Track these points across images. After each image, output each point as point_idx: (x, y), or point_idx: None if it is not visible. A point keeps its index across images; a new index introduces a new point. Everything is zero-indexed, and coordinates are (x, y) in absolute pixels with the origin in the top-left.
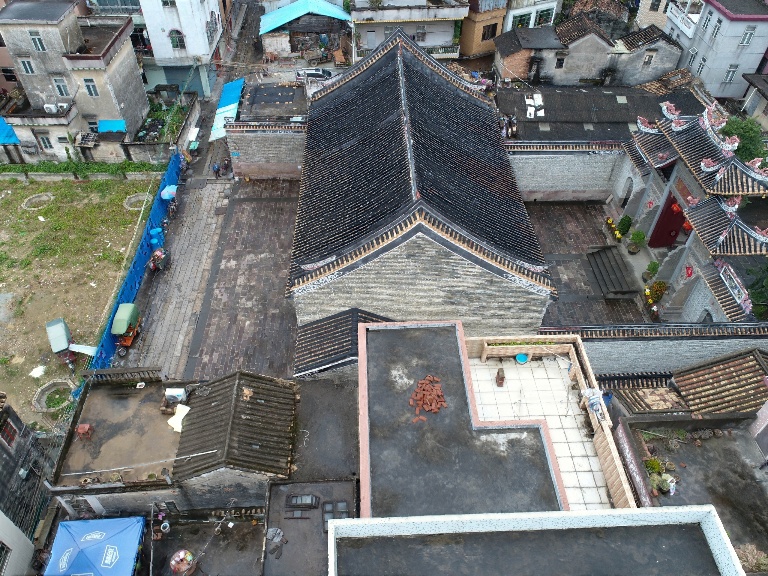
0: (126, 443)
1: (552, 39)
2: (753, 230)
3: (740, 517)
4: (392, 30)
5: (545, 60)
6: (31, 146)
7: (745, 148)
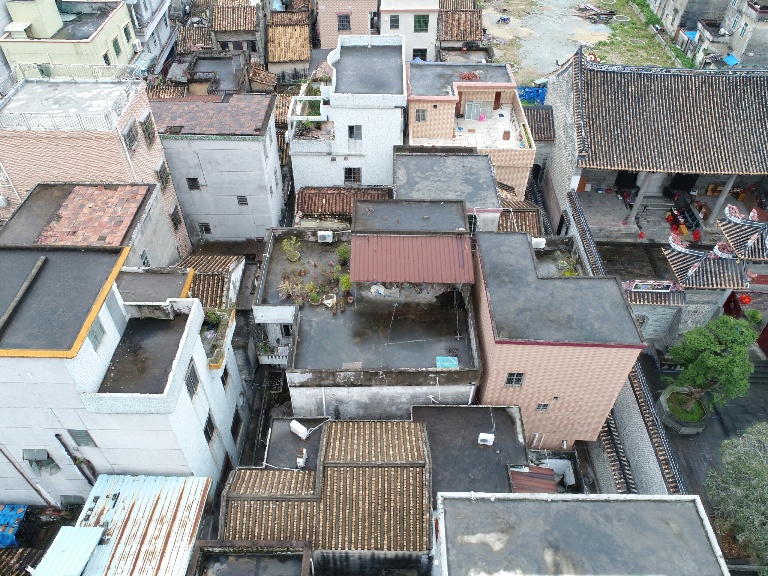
0: (461, 60)
1: None
2: None
3: None
4: None
5: None
6: (693, 45)
7: None
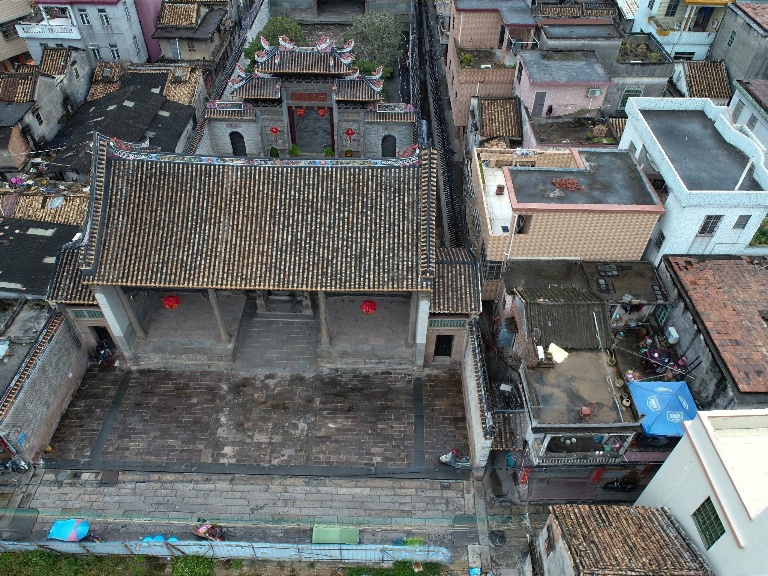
0: (585, 387)
1: (7, 106)
2: (372, 76)
3: (575, 131)
4: None
5: (30, 125)
6: None
7: None
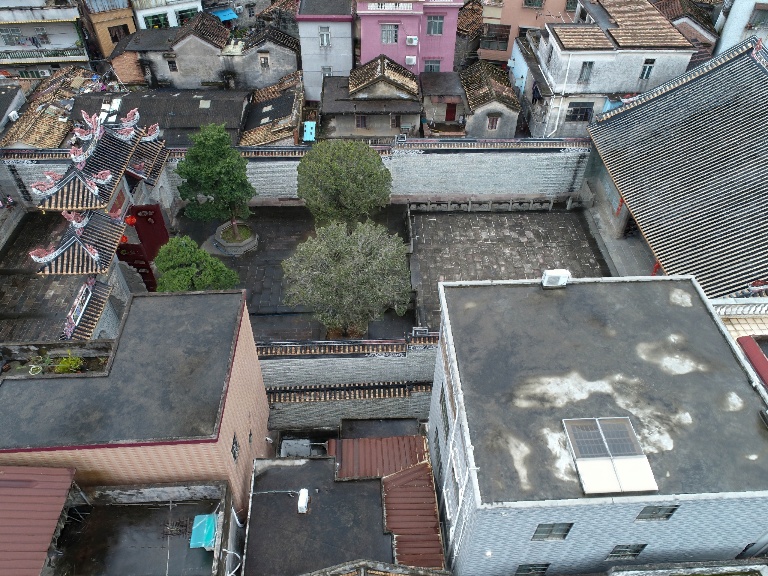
0: None
1: (165, 41)
2: (86, 248)
3: None
4: (8, 32)
5: (155, 63)
6: None
7: (208, 157)
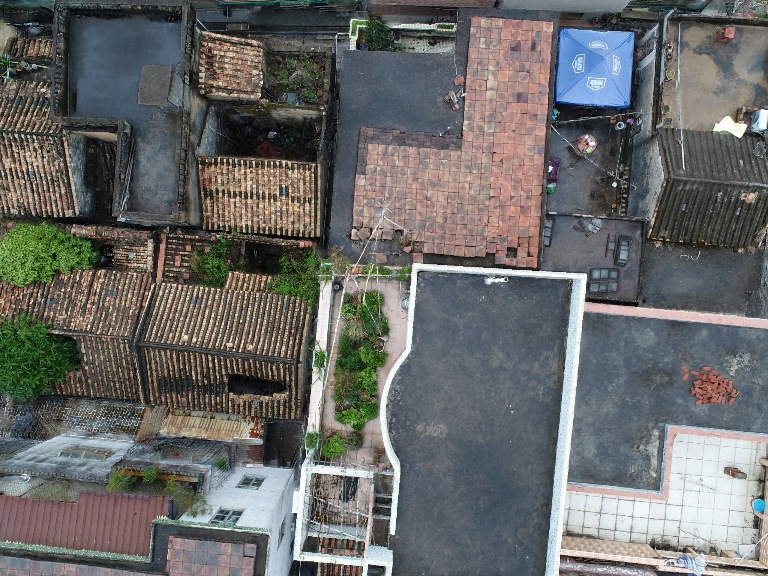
0: (708, 78)
1: None
2: None
3: None
4: None
5: None
6: None
7: None
